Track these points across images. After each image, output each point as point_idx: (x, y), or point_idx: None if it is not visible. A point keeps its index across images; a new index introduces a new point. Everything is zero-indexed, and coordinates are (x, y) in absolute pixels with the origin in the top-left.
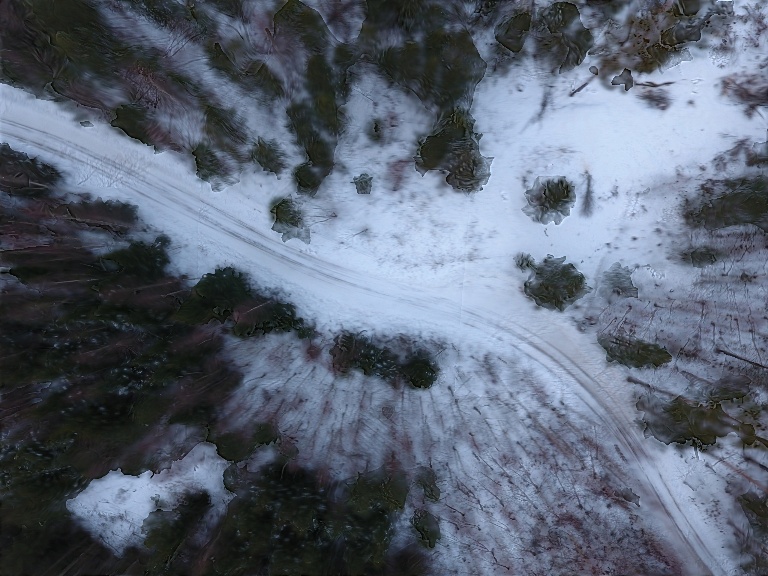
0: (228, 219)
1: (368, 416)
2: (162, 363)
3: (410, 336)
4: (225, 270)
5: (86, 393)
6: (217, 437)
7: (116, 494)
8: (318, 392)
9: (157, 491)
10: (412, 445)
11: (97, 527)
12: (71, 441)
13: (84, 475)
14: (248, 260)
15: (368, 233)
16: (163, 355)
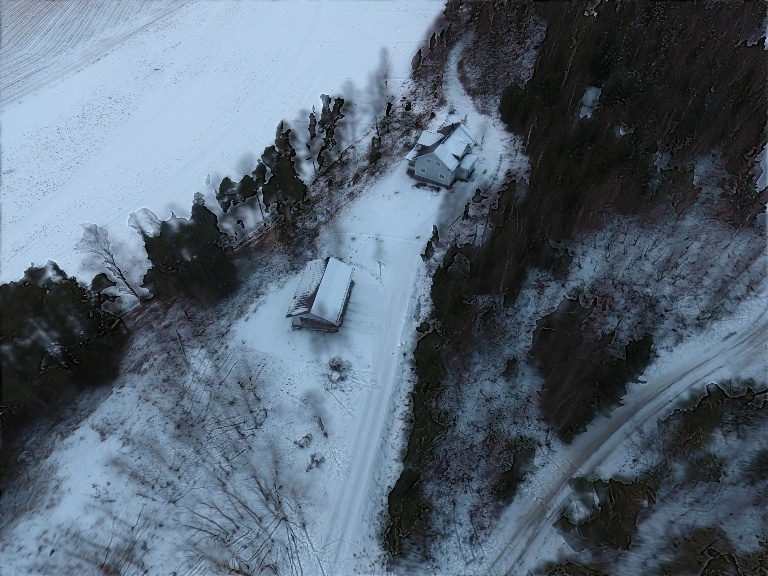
0: None
1: None
2: None
3: (757, 222)
4: None
5: None
6: None
7: None
8: None
9: None
10: (679, 221)
11: None
12: (668, 86)
13: None
14: (762, 165)
15: None
16: None
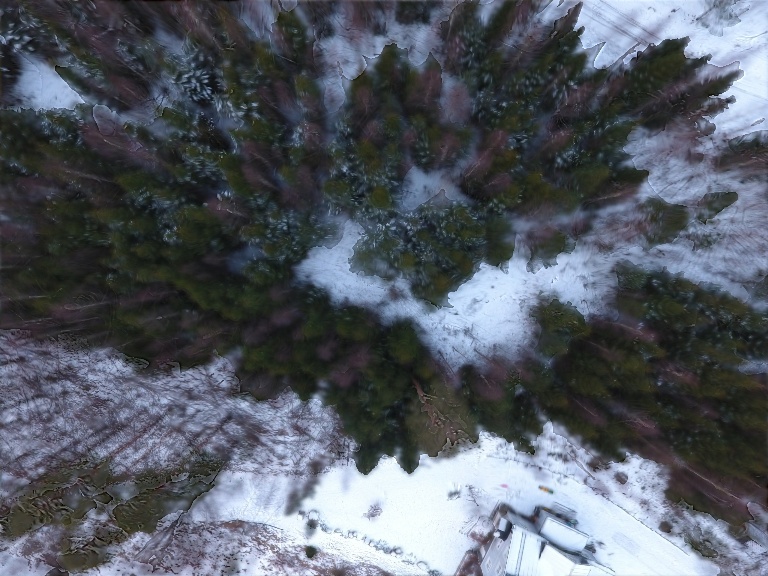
0: (621, 17)
1: (739, 232)
2: (614, 126)
3: None
4: (635, 59)
5: (523, 159)
6: (663, 207)
7: (468, 304)
8: (691, 204)
9: (510, 303)
10: None
11: (437, 342)
12: (519, 201)
13: (510, 247)
14: None
15: (766, 36)
16: (614, 119)
